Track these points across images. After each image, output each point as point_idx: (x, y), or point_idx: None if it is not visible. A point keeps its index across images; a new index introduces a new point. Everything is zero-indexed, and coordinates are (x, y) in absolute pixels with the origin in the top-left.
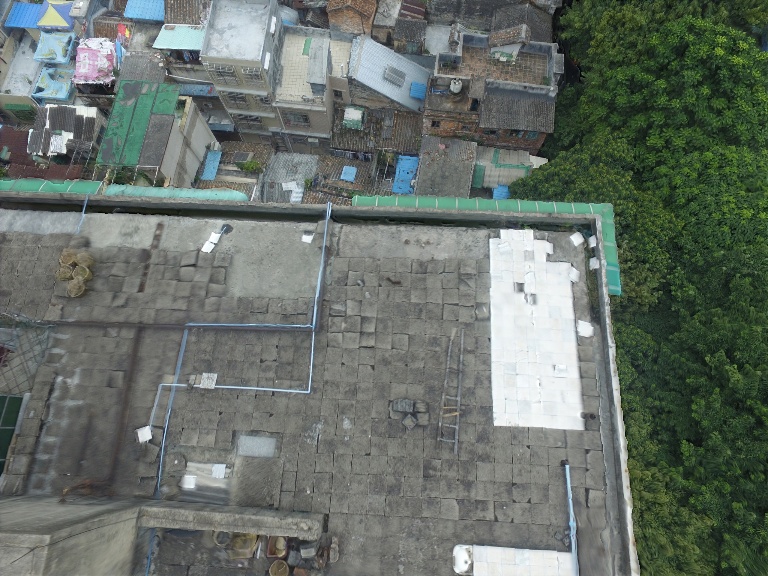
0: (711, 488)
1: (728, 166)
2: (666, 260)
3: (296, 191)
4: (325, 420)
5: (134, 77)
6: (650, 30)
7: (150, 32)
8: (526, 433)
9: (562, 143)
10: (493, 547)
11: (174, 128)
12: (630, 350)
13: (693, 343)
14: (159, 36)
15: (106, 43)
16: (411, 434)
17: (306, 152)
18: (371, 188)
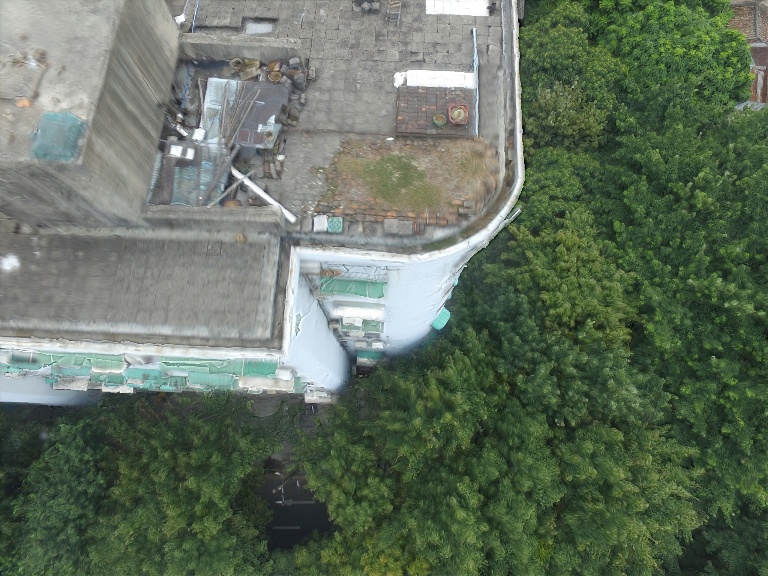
0: (637, 254)
1: (666, 16)
2: (613, 100)
3: None
4: (307, 11)
5: None
6: None
7: None
8: (448, 17)
9: None
10: (421, 70)
11: None
12: (579, 172)
13: (630, 156)
14: None
15: None
16: (367, 18)
17: None
18: None
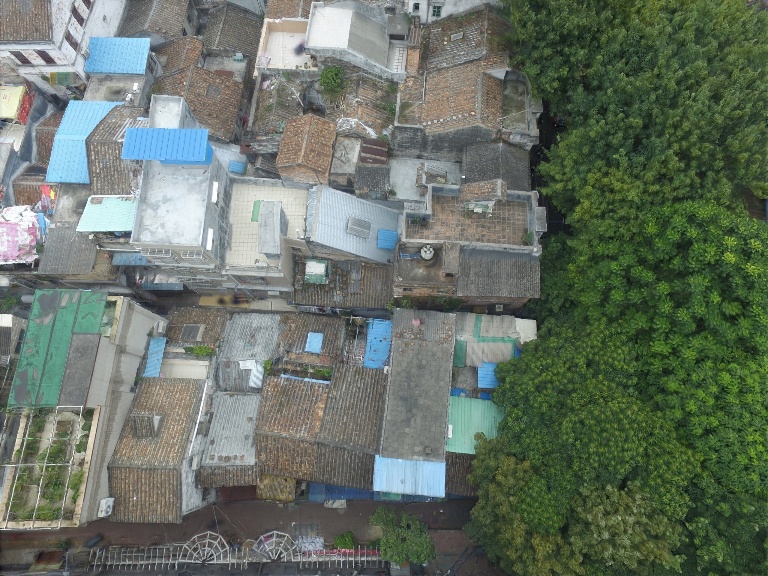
0: None
1: (750, 392)
2: (686, 505)
3: (255, 370)
4: None
5: (60, 254)
6: (643, 202)
7: (78, 194)
8: None
9: (551, 306)
10: None
11: (102, 345)
12: None
13: None
14: (84, 214)
15: (27, 214)
16: None
17: (268, 296)
18: (340, 364)
